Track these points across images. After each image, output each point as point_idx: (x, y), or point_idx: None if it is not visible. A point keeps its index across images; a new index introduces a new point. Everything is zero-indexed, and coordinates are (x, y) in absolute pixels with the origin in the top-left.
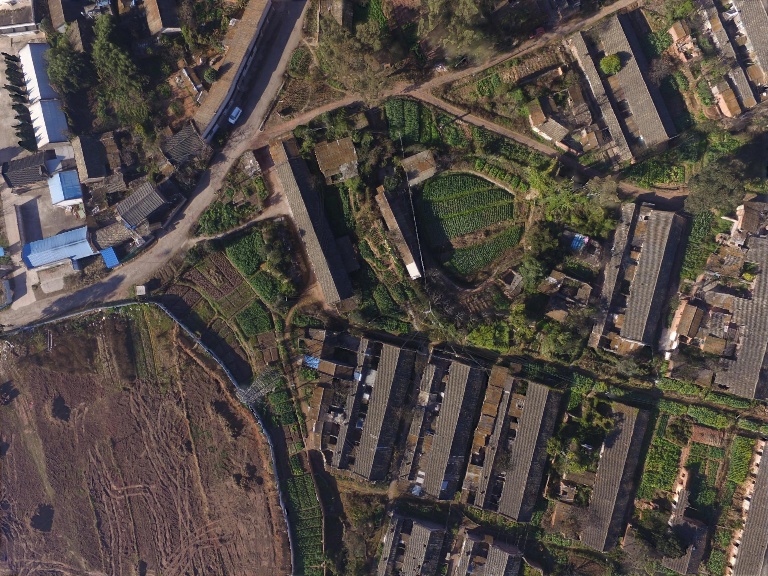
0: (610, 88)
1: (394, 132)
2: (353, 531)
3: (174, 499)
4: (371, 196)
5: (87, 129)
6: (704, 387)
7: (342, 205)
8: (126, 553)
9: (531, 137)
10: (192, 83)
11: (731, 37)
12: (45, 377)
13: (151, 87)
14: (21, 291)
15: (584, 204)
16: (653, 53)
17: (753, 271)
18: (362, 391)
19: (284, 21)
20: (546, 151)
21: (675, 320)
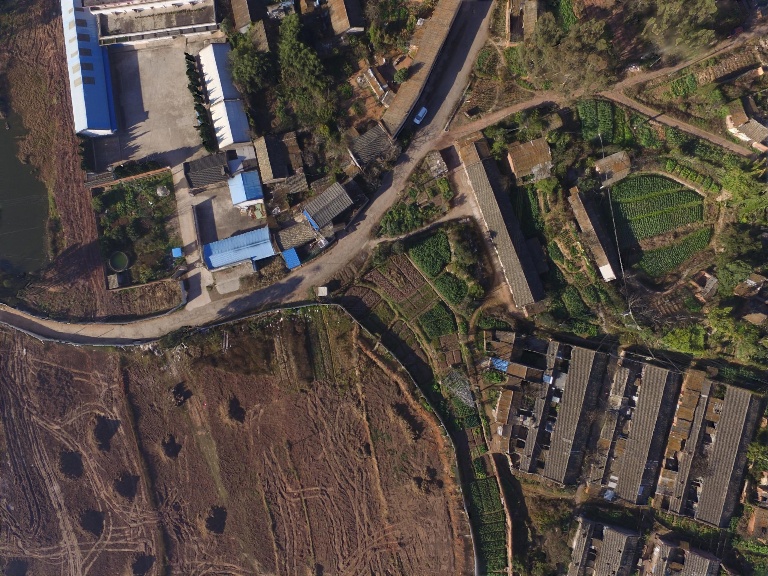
0: None
1: (587, 133)
2: (539, 536)
3: (352, 502)
4: (564, 197)
5: (266, 129)
6: None
7: (530, 206)
8: (301, 556)
9: (726, 138)
10: (378, 83)
11: None
12: (219, 378)
13: (332, 87)
14: (195, 292)
15: None
16: None
17: None
18: (551, 394)
19: (470, 21)
20: (742, 152)
21: None
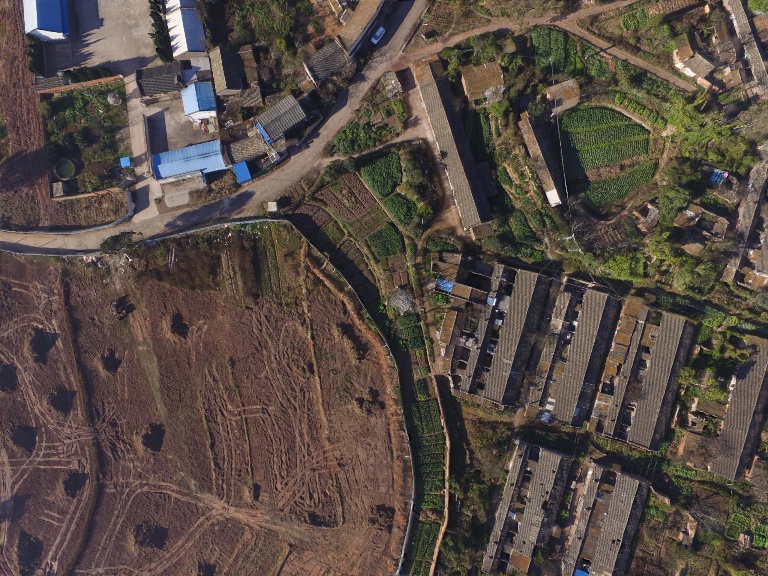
0: (755, 28)
1: (539, 60)
2: (477, 458)
3: (293, 421)
4: (514, 122)
5: (222, 42)
6: None
7: (482, 131)
8: (239, 475)
9: (673, 73)
10: (337, 0)
11: None
12: (164, 293)
13: (291, 3)
14: (143, 204)
15: (722, 142)
16: None
17: None
18: (494, 317)
19: None
20: (687, 88)
21: None
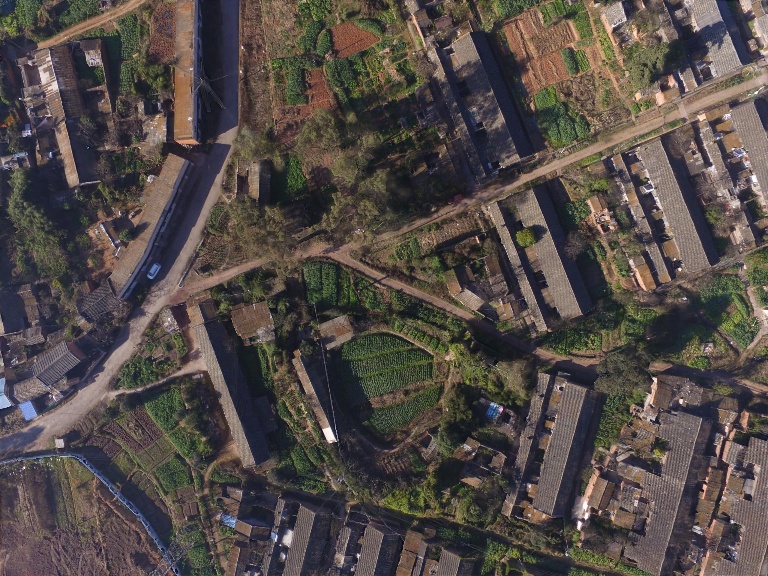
0: (527, 258)
1: (312, 295)
2: None
3: None
4: (288, 359)
5: (6, 278)
6: (614, 558)
7: (260, 364)
8: None
9: (449, 302)
10: (110, 239)
11: (647, 212)
12: None
13: (70, 238)
14: None
15: None
16: (571, 223)
17: (665, 445)
18: (279, 550)
19: (204, 176)
20: (464, 316)
21: (588, 489)
